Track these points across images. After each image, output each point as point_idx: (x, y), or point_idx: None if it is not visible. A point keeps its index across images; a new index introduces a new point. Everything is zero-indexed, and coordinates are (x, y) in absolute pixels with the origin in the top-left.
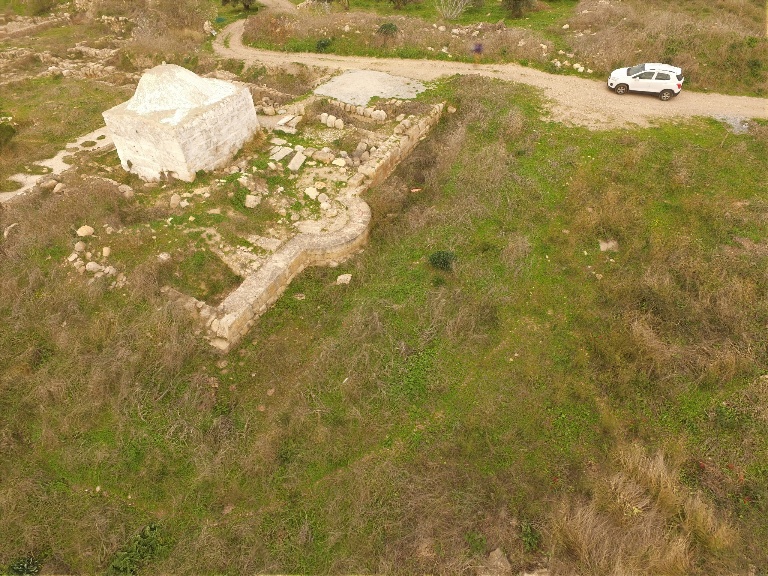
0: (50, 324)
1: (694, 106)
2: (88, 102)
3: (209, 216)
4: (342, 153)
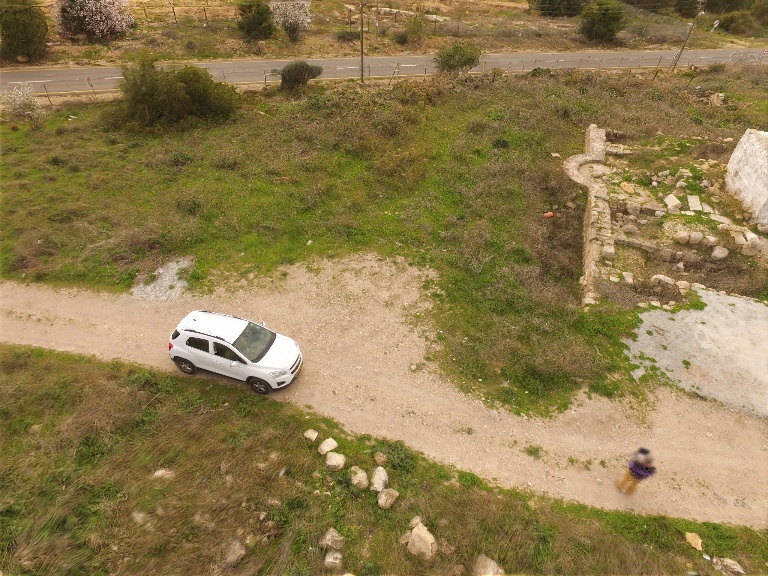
0: None
1: None
2: None
3: None
4: None
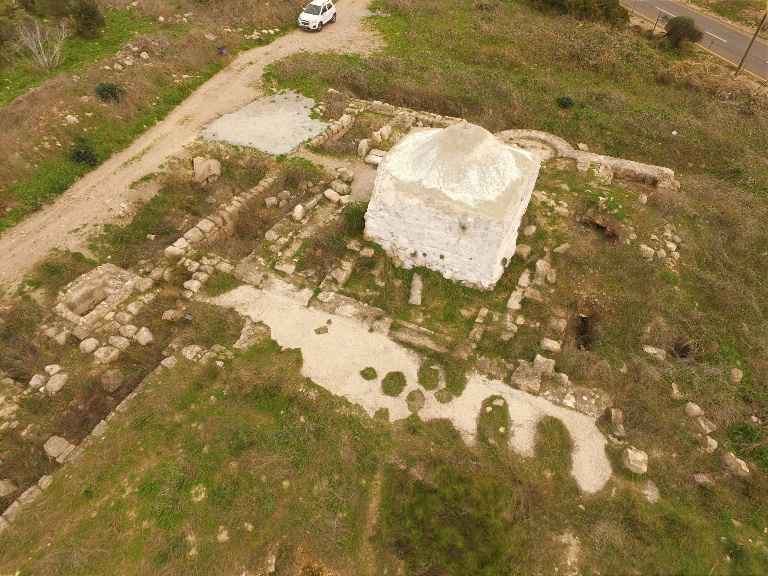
0: (743, 246)
1: None
2: (187, 468)
3: None
4: None
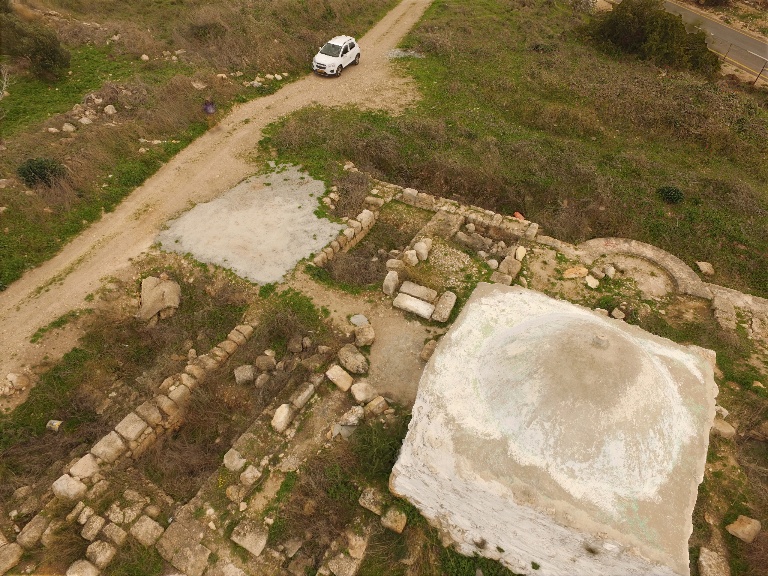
0: None
1: (370, 58)
2: None
3: (731, 369)
4: (485, 254)
